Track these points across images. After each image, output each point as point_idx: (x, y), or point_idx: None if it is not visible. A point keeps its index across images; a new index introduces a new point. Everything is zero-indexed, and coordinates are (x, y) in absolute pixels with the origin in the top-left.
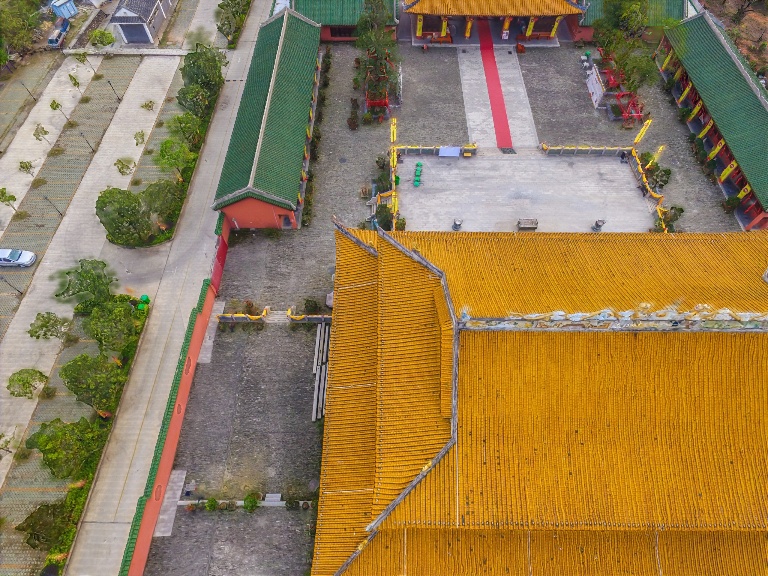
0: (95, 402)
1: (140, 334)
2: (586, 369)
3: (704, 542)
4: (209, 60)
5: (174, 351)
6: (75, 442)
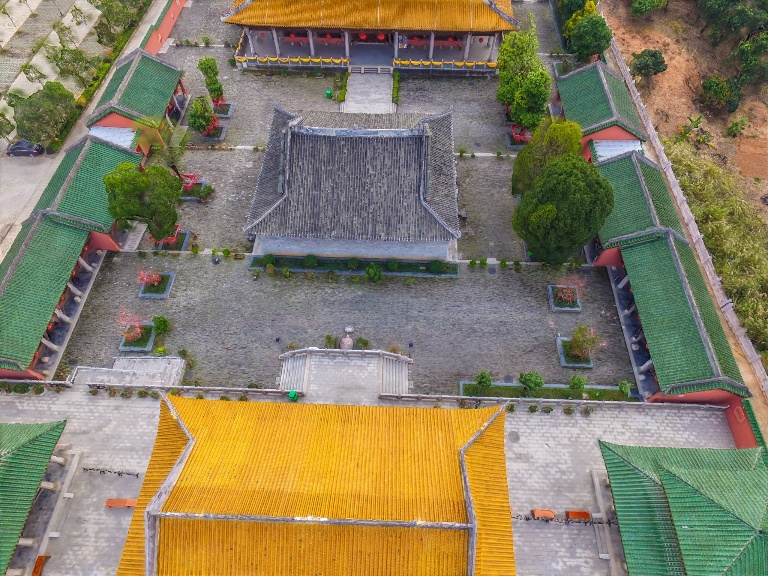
0: (129, 4)
1: None
2: None
3: (400, 8)
4: None
5: None
6: None
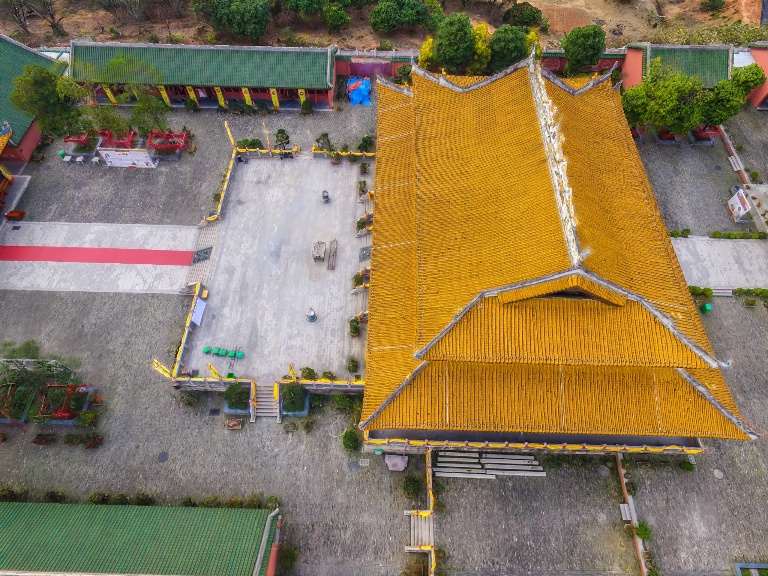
0: None
1: None
2: (576, 199)
3: None
4: None
5: None
6: None
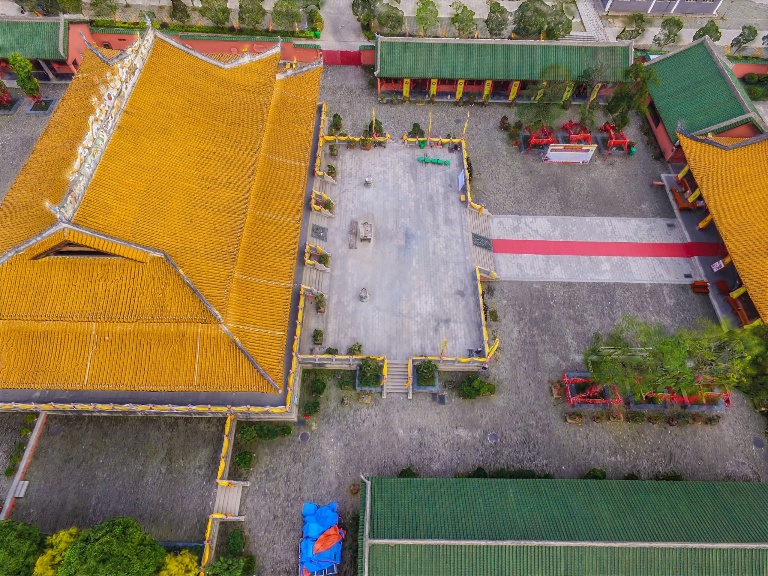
0: None
1: (293, 37)
2: None
3: None
4: (539, 10)
5: None
6: (213, 7)
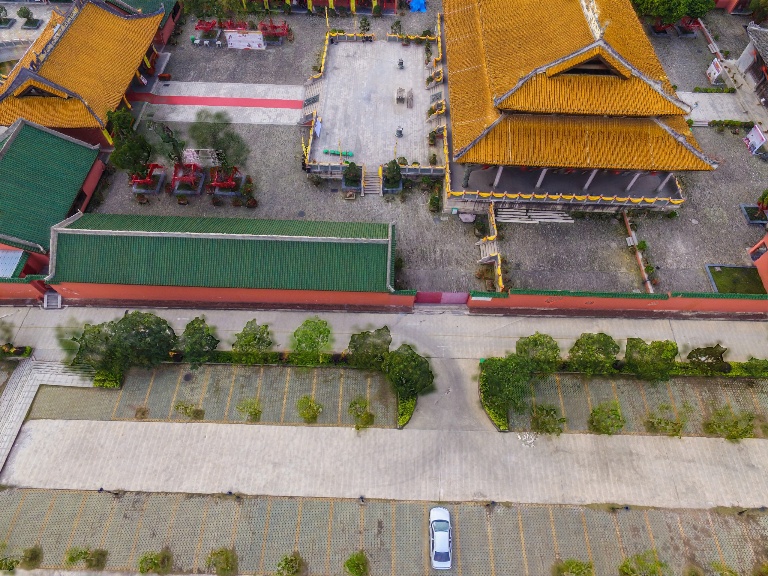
0: None
1: None
2: None
3: None
4: (137, 315)
5: (531, 329)
6: None
